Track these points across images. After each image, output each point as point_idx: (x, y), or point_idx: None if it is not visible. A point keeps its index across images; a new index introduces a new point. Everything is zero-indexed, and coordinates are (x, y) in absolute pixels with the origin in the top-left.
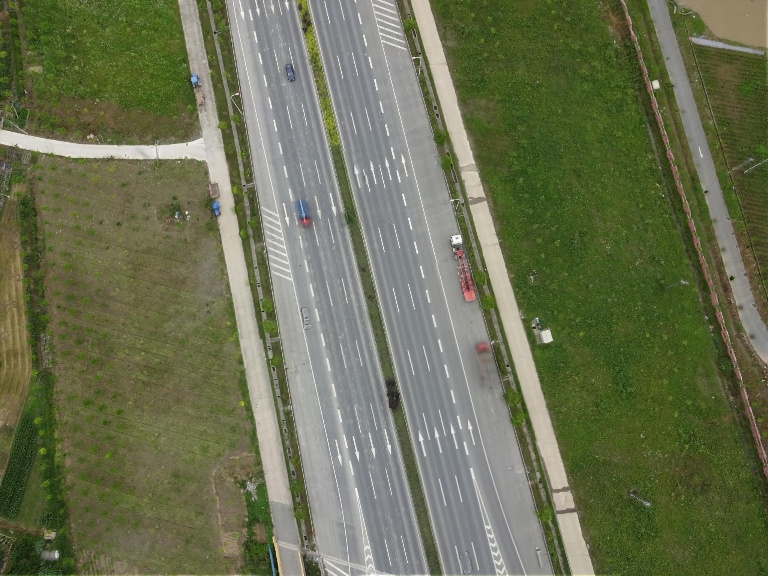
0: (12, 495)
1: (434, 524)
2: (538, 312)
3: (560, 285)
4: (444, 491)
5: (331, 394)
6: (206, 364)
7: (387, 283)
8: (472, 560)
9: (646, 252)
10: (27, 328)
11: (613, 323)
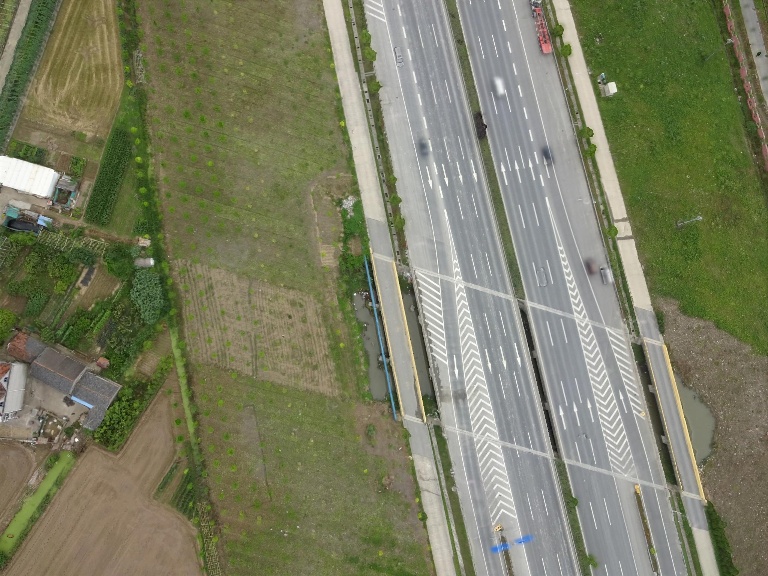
0: (105, 202)
1: (514, 243)
2: (603, 69)
3: (623, 46)
4: (523, 215)
5: (422, 126)
6: (304, 89)
7: (473, 32)
8: (547, 275)
9: (691, 27)
10: (118, 44)
11: (664, 84)
